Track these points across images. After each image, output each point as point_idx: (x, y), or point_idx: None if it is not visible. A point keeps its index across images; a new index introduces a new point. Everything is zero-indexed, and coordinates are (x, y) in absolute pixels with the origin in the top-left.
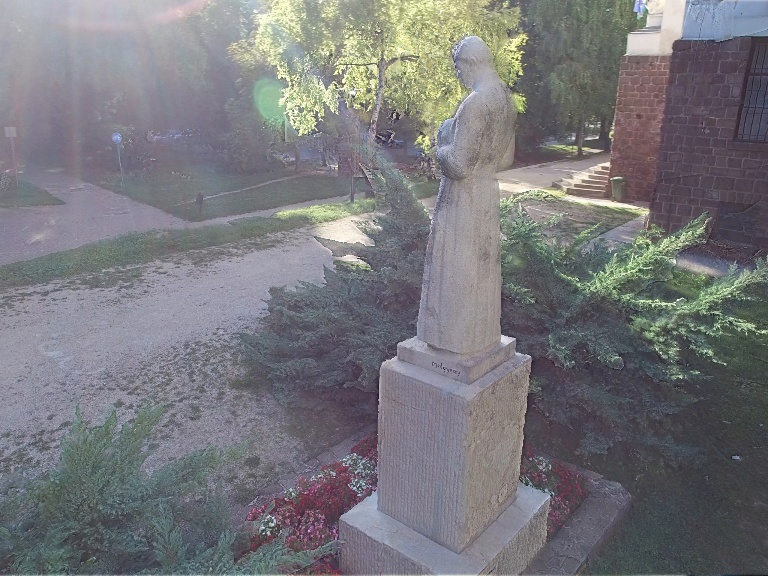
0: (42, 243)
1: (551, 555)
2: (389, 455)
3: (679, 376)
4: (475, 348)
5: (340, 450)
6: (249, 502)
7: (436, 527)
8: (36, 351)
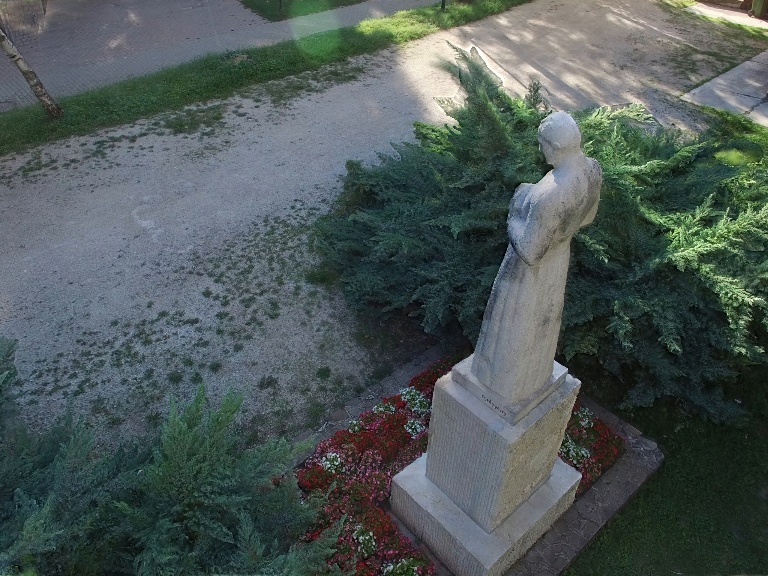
0: (124, 47)
1: (575, 517)
2: (438, 447)
3: (742, 350)
4: (524, 392)
5: (401, 376)
6: (319, 427)
7: (473, 509)
8: (131, 218)
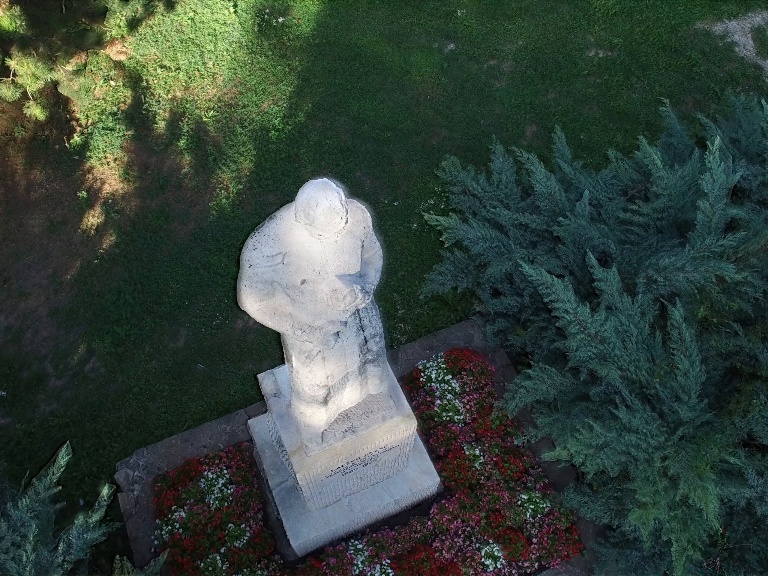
0: None
1: None
2: None
3: None
4: None
5: None
6: None
7: None
8: None
